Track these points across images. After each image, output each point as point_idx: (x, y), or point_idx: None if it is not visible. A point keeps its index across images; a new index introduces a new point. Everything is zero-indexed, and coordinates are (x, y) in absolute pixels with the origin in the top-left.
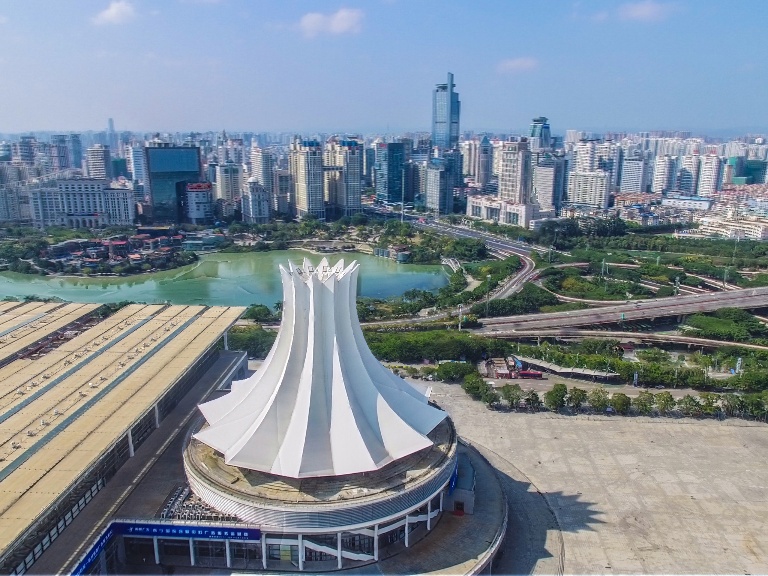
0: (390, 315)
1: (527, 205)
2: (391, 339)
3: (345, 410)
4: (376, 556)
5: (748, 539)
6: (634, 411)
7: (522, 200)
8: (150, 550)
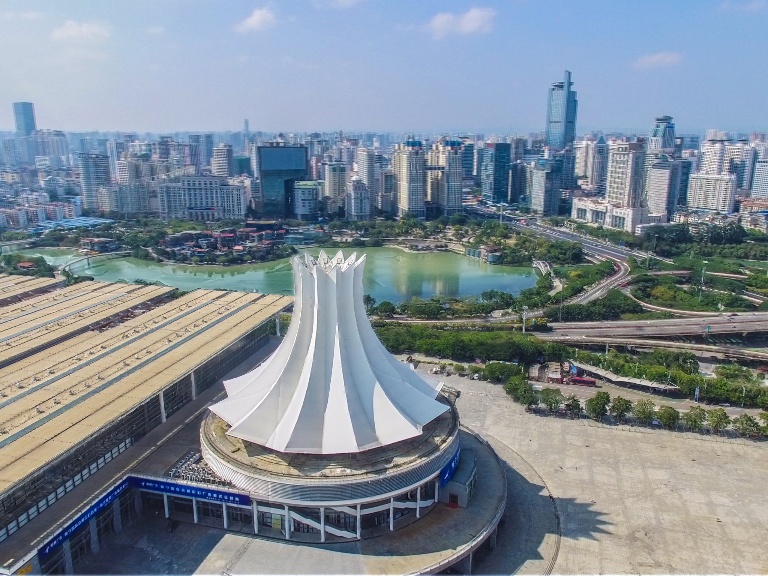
0: (462, 314)
1: (635, 209)
2: (449, 337)
3: (340, 394)
4: (359, 535)
5: (767, 569)
6: (683, 426)
7: (631, 203)
8: (162, 505)
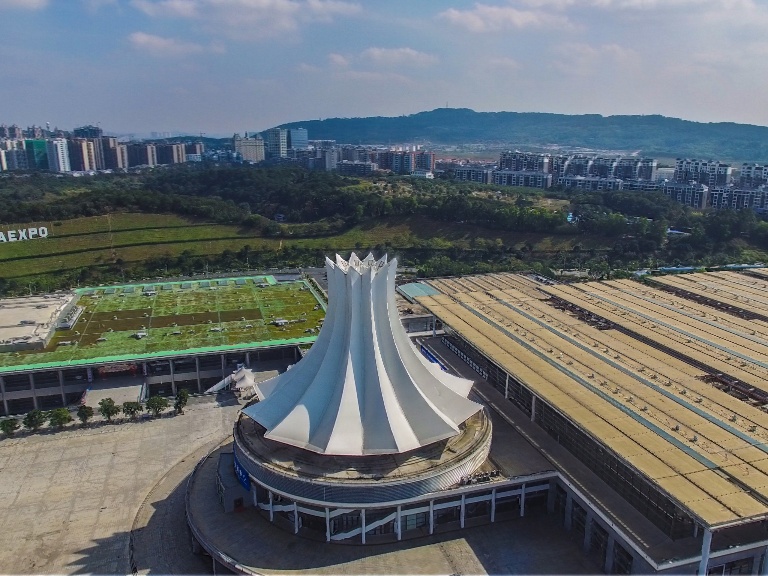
0: None
1: None
2: None
3: None
4: None
5: None
6: None
7: None
8: None
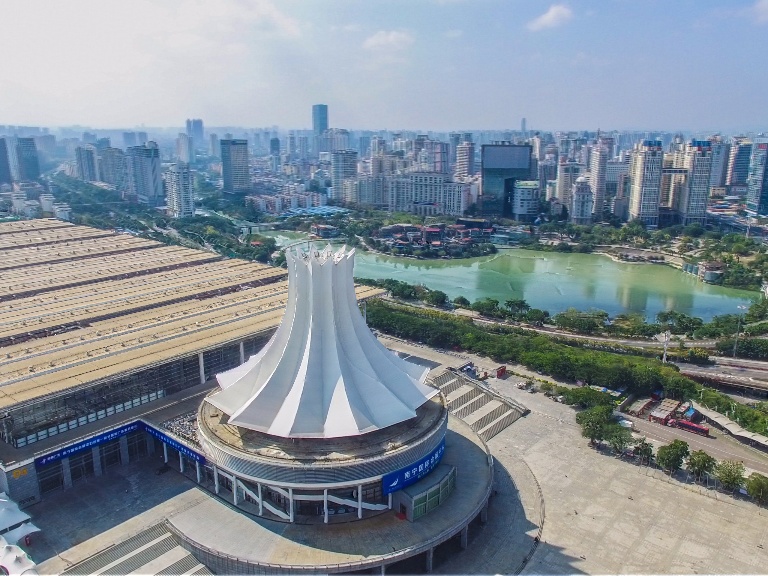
0: None
1: None
2: (565, 353)
3: (301, 382)
4: (291, 518)
5: None
6: None
7: None
8: None
